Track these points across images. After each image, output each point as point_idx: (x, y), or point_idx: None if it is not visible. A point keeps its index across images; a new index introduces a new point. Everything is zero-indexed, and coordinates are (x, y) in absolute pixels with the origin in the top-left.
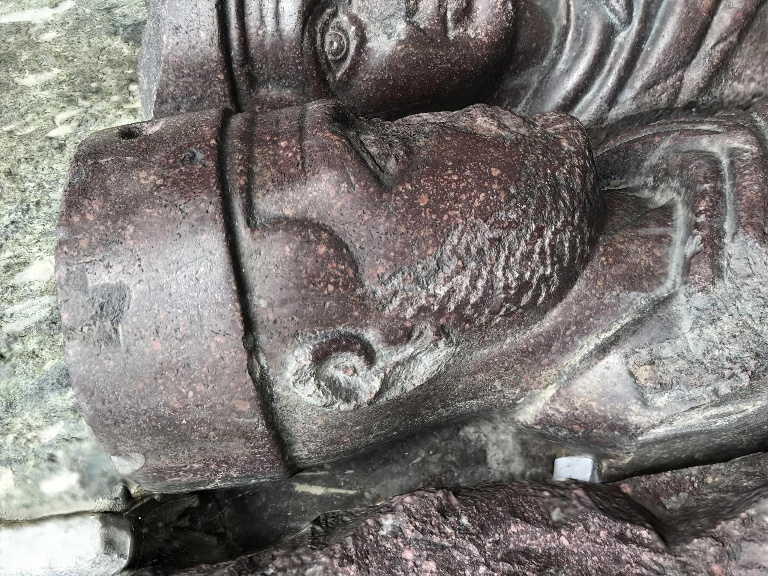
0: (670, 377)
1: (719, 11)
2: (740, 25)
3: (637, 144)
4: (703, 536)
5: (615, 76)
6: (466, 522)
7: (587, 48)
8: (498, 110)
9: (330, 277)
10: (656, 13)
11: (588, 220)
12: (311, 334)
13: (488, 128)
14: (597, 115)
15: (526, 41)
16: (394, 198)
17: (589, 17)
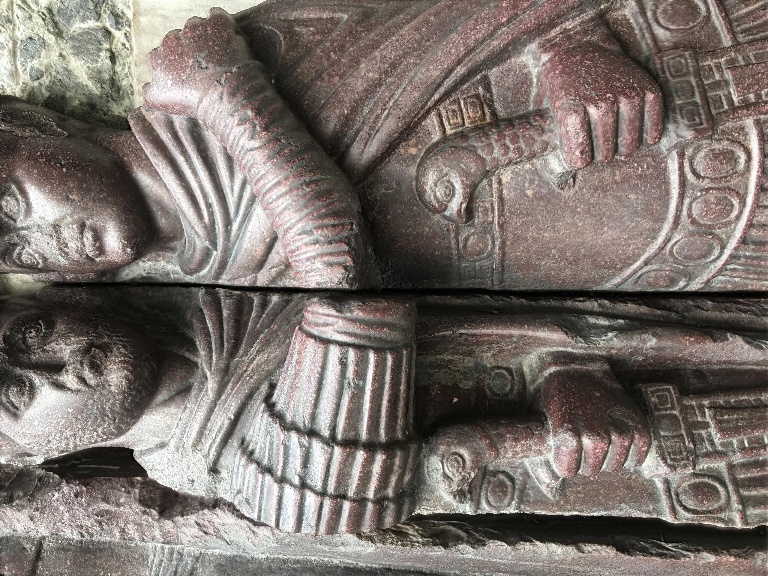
0: (157, 477)
1: (272, 253)
2: (284, 263)
3: (199, 338)
4: (170, 519)
5: (214, 271)
6: (83, 501)
7: (195, 255)
8: (83, 366)
9: (2, 445)
10: (233, 246)
11: (127, 416)
12: (3, 455)
13: (72, 383)
14: (210, 282)
15: (165, 234)
16: (23, 422)
17: (194, 239)
